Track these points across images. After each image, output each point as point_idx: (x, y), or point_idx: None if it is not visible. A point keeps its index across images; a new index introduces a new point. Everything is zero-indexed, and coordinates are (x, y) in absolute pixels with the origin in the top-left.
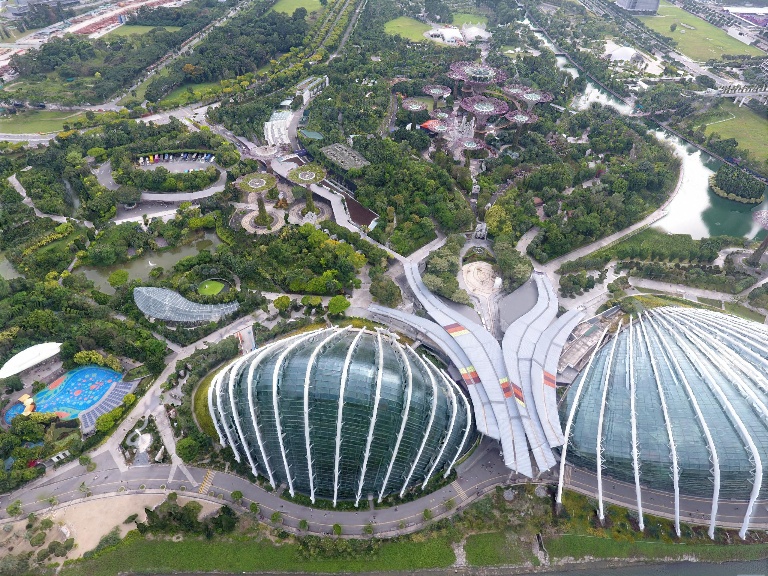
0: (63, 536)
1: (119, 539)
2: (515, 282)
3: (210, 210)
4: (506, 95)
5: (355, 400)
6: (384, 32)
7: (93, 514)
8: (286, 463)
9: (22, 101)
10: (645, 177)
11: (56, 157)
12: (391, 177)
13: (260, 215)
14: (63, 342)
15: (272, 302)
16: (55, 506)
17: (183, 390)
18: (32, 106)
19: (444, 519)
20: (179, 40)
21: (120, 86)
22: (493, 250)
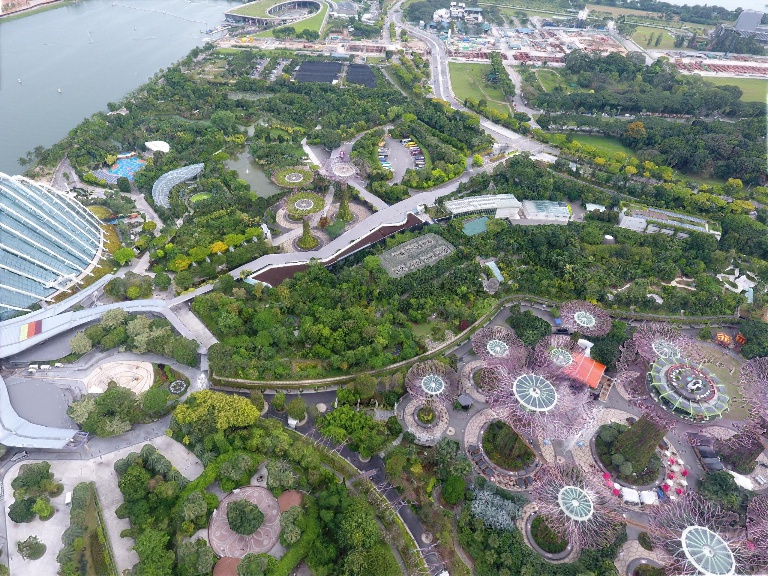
0: None
1: None
2: None
3: None
4: None
5: None
6: None
7: None
8: None
9: None
10: None
11: None
12: None
13: None
14: None
15: None
16: None
17: None
18: None
19: None
20: (739, 111)
21: (579, 108)
22: None
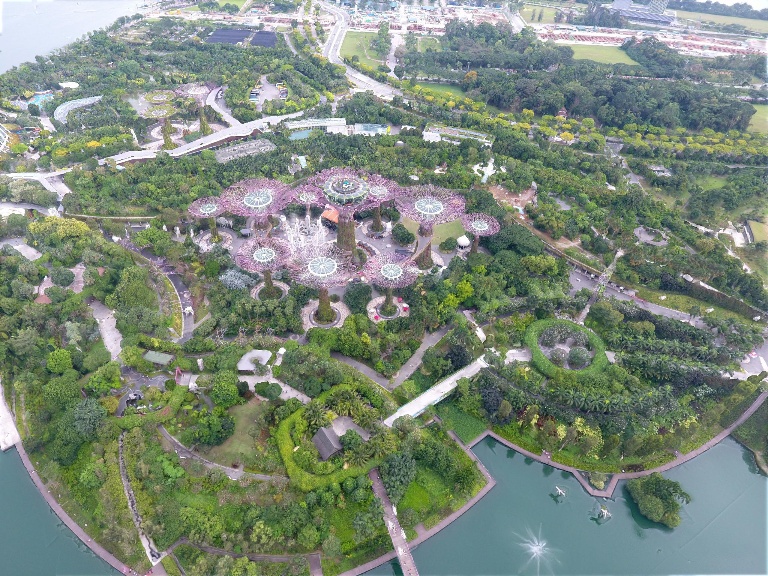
0: None
1: None
2: None
3: None
4: None
5: None
6: None
7: None
8: None
9: None
10: (47, 391)
11: None
12: None
13: None
14: None
15: None
16: None
17: None
18: None
19: None
20: None
21: (441, 65)
22: None
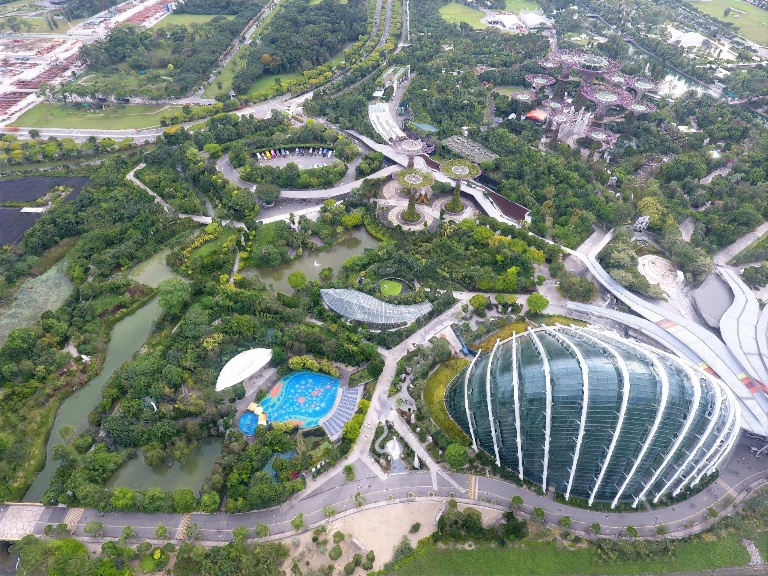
0: (355, 548)
1: (413, 549)
2: (698, 275)
3: (351, 207)
4: (608, 84)
5: (670, 403)
6: (443, 19)
7: (374, 524)
8: (575, 467)
9: (107, 95)
10: None
11: (168, 154)
12: (531, 170)
13: (410, 211)
14: (268, 348)
15: (460, 301)
16: (331, 517)
17: (415, 394)
18: (116, 100)
19: (729, 517)
20: (240, 29)
21: None
22: (657, 243)
